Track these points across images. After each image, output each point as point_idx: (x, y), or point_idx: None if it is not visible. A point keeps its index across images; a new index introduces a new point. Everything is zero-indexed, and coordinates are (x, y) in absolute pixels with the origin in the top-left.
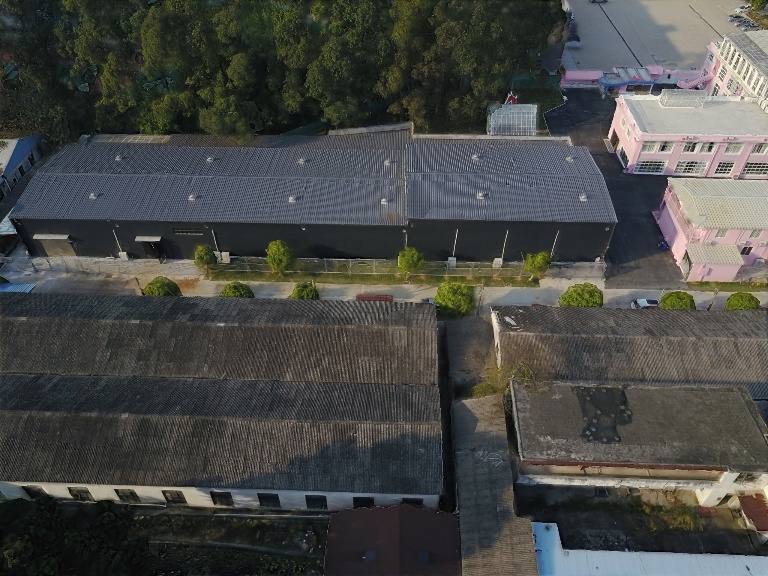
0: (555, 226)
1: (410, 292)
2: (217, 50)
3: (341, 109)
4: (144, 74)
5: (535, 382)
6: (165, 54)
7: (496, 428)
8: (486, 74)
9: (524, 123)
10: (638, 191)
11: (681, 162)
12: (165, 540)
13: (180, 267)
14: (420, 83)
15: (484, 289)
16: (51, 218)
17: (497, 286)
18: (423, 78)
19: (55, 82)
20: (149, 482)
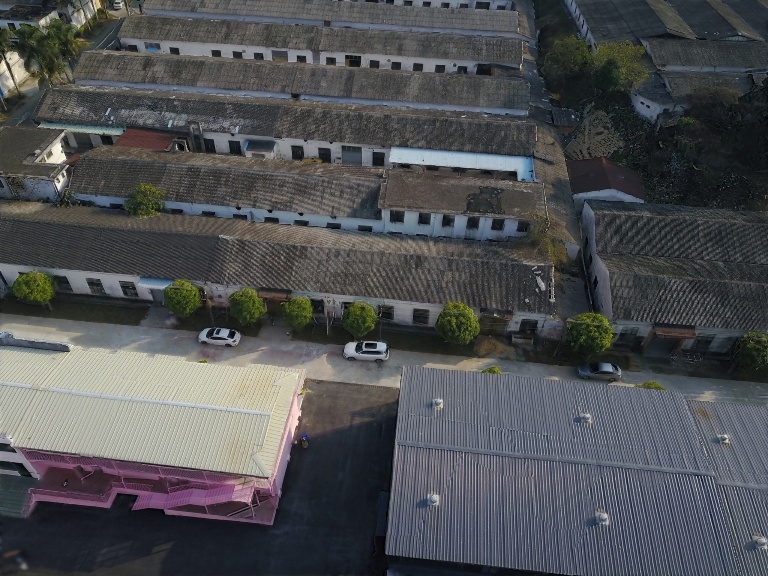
0: None
1: None
2: None
3: None
4: None
5: None
6: None
7: (553, 217)
8: None
9: None
10: None
11: None
12: None
13: None
14: None
15: None
16: None
17: None
18: None
19: None
20: None
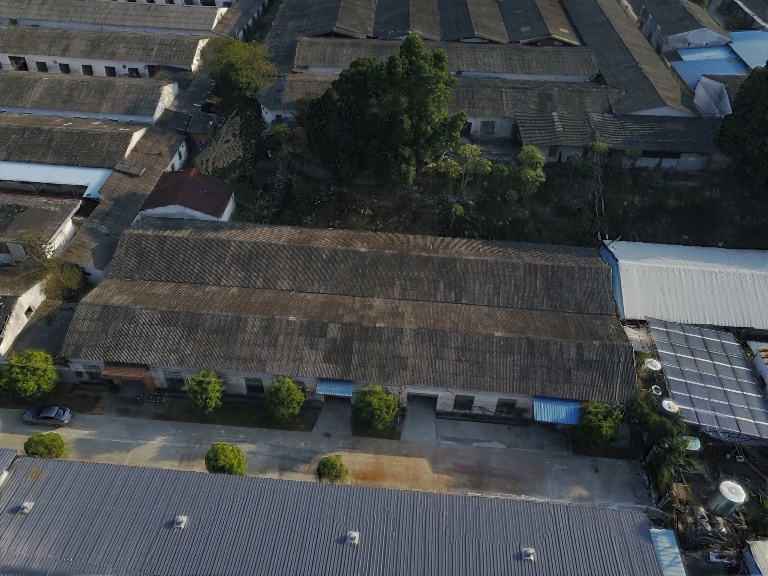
0: None
1: (69, 448)
2: None
3: None
4: None
5: None
6: None
7: (82, 238)
8: None
9: None
10: None
11: None
12: None
13: None
14: None
15: None
16: (573, 506)
17: None
18: None
19: None
20: (340, 230)
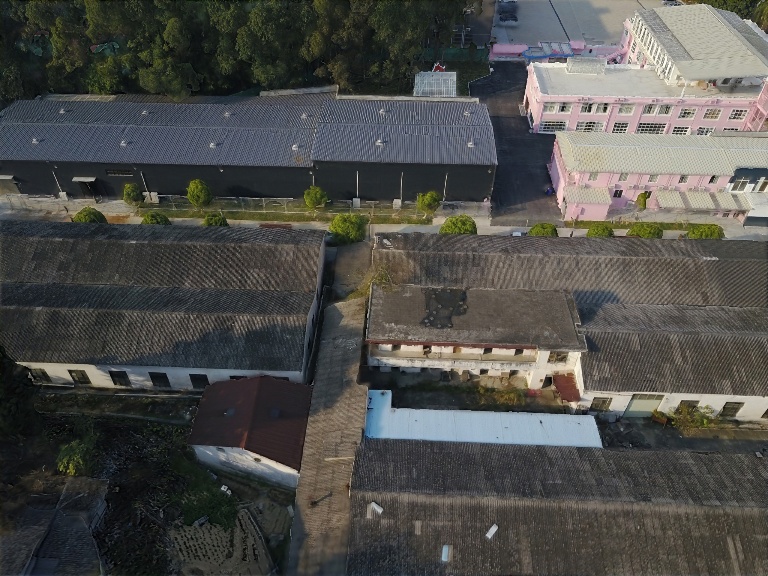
0: (443, 168)
1: (316, 227)
2: (154, 15)
3: (269, 71)
4: (88, 37)
5: (391, 284)
6: (107, 18)
7: (356, 322)
8: (401, 40)
9: (445, 89)
10: (539, 147)
11: (580, 122)
12: (70, 411)
13: (114, 206)
14: (345, 49)
15: (382, 225)
16: None
17: (394, 223)
18: (342, 43)
19: (10, 45)
20: (55, 360)
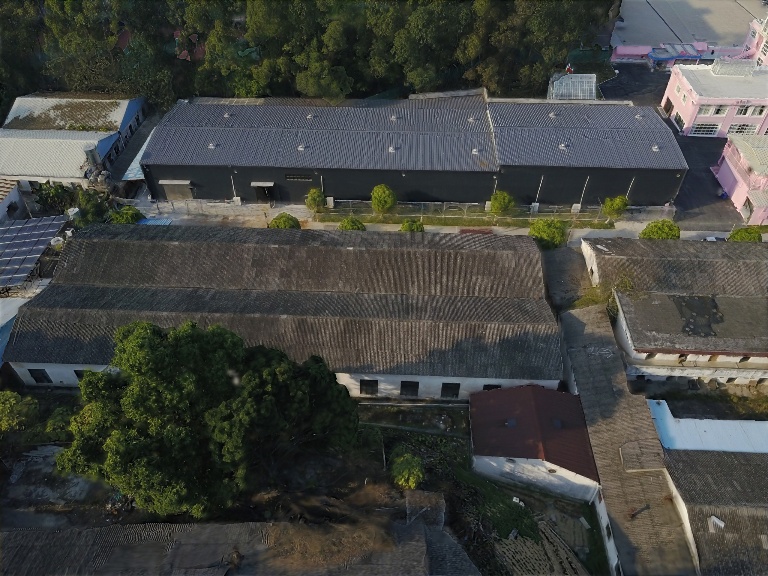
0: (632, 173)
1: (499, 232)
2: (315, 18)
3: (423, 74)
4: (247, 40)
5: (636, 291)
6: None
7: (603, 330)
8: (556, 42)
9: (584, 91)
10: (695, 150)
11: (733, 125)
12: None
13: (289, 211)
14: (492, 52)
15: None
16: (178, 164)
17: (577, 228)
18: (500, 45)
19: (161, 48)
20: None
